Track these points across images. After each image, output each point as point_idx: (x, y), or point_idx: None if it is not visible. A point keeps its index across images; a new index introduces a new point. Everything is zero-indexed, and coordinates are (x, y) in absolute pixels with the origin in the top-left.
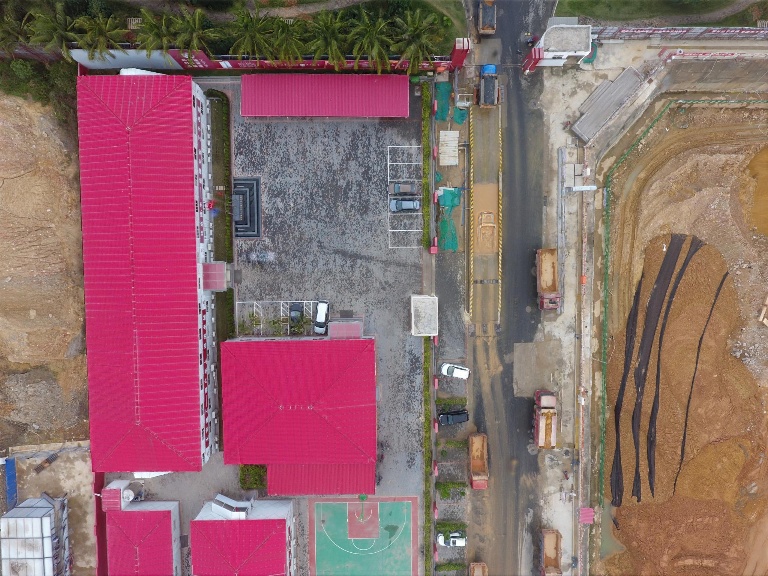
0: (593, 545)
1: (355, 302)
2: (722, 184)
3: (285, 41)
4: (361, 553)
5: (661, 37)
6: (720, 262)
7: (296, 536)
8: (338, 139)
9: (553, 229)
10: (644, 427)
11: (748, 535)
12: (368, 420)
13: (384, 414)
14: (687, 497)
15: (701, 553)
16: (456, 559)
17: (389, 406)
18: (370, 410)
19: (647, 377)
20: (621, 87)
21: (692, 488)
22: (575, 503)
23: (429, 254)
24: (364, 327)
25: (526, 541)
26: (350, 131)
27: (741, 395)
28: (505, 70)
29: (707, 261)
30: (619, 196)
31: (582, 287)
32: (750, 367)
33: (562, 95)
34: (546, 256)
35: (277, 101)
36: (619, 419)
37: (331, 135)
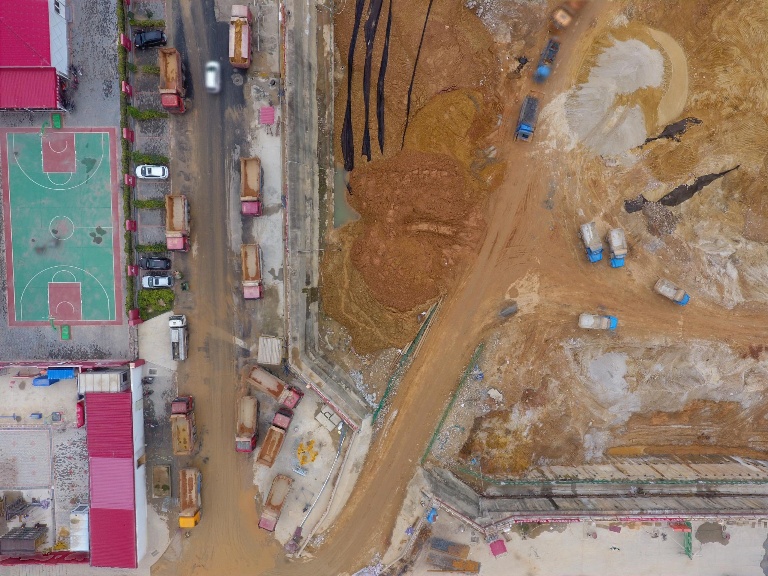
0: (325, 211)
1: None
2: None
3: None
4: (57, 188)
5: None
6: None
7: None
8: None
9: None
10: (374, 82)
11: (488, 203)
12: (39, 17)
13: (77, 37)
14: (415, 150)
15: (437, 218)
16: (160, 198)
17: (82, 29)
18: (41, 6)
19: (377, 30)
20: None
21: (420, 141)
22: (282, 137)
23: None
24: None
25: (234, 180)
26: None
27: (472, 45)
28: None
29: None
30: None
31: None
32: (485, 21)
33: None
34: None
35: None
36: (352, 79)
37: None
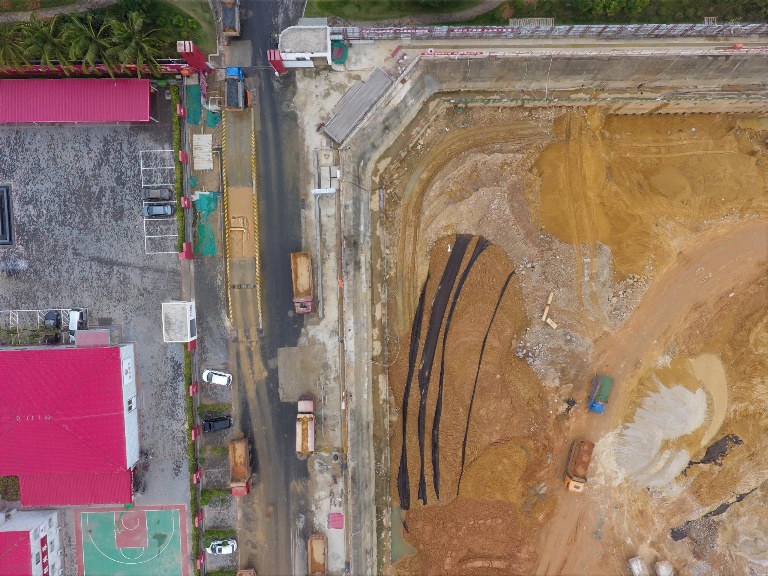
0: (383, 549)
1: (113, 309)
2: (500, 184)
3: (3, 46)
4: (130, 562)
5: (411, 37)
6: (506, 262)
7: (63, 547)
8: (89, 144)
9: (312, 232)
10: (428, 429)
11: (539, 535)
12: (115, 429)
13: (148, 422)
14: (470, 499)
15: (491, 555)
16: (228, 566)
17: (153, 414)
18: (117, 419)
19: (431, 379)
20: (372, 88)
21: (475, 490)
22: (345, 508)
23: (187, 259)
24: (124, 334)
25: (299, 547)
26: (101, 136)
27: (523, 395)
28: (256, 72)
29: (492, 261)
30: (401, 197)
31: (343, 290)
32: (535, 367)
33: (315, 97)
34: (301, 260)
35: (14, 107)
36: (406, 422)
37: (82, 140)
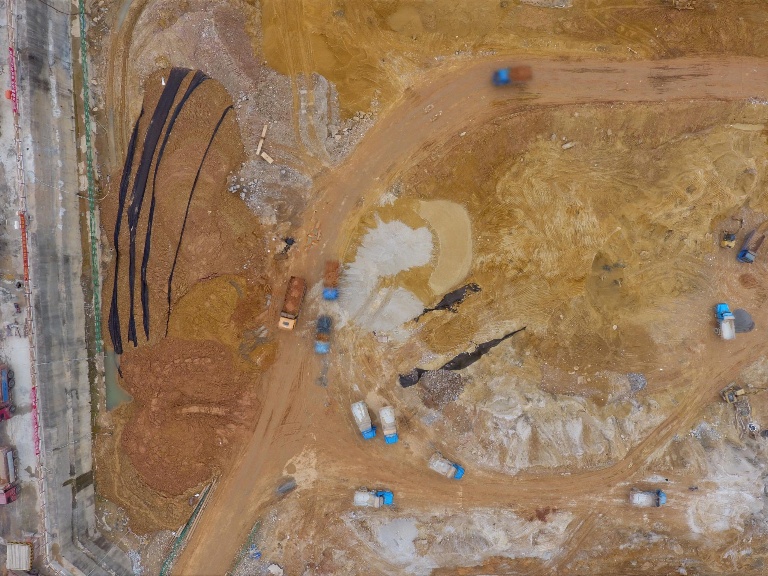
0: (97, 395)
1: None
2: (207, 9)
3: None
4: None
5: None
6: (223, 96)
7: None
8: None
9: None
10: (138, 268)
11: (261, 382)
12: None
13: None
14: (178, 338)
15: (208, 400)
16: None
17: None
18: None
19: (140, 215)
20: None
21: (182, 328)
22: None
23: None
24: None
25: None
26: None
27: (234, 231)
28: None
29: (208, 95)
30: (110, 27)
31: (17, 105)
32: (250, 204)
33: None
34: None
35: None
36: (119, 262)
37: None
